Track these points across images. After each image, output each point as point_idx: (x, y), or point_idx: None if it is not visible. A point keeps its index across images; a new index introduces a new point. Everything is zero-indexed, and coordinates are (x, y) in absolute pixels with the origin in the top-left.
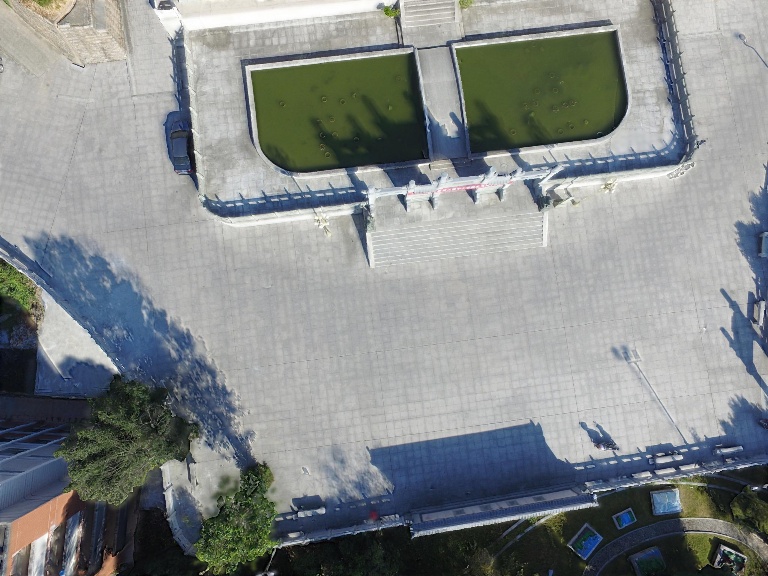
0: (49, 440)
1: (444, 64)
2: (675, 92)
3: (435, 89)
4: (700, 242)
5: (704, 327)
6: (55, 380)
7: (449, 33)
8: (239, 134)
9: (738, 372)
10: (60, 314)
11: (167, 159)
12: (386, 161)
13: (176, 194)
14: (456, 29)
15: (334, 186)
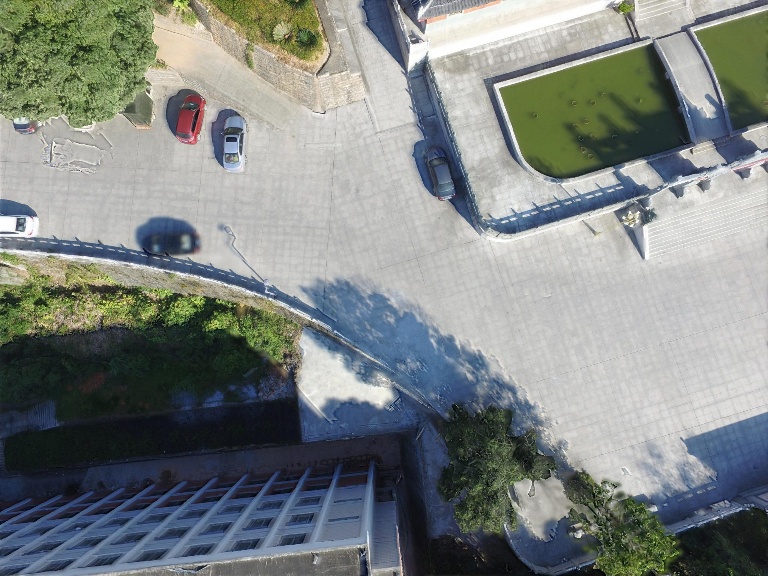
0: (318, 485)
1: (687, 49)
2: None
3: (685, 74)
4: None
5: None
6: (321, 424)
7: (681, 19)
8: (498, 151)
9: None
10: (321, 358)
11: (423, 188)
12: (648, 153)
13: (439, 220)
14: (687, 14)
15: (601, 186)
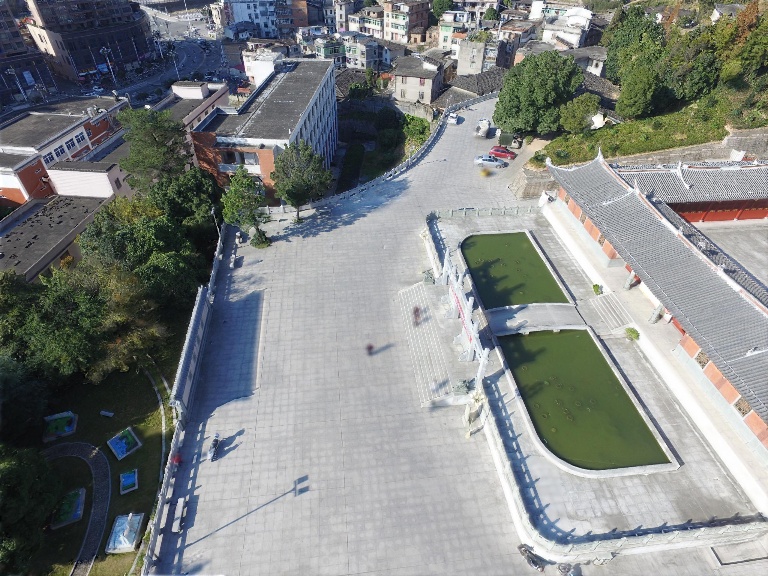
0: None
1: (568, 319)
2: None
3: (544, 312)
4: None
5: None
6: None
7: (599, 327)
8: (482, 230)
9: None
10: None
11: None
12: (479, 290)
13: None
14: (605, 332)
15: None
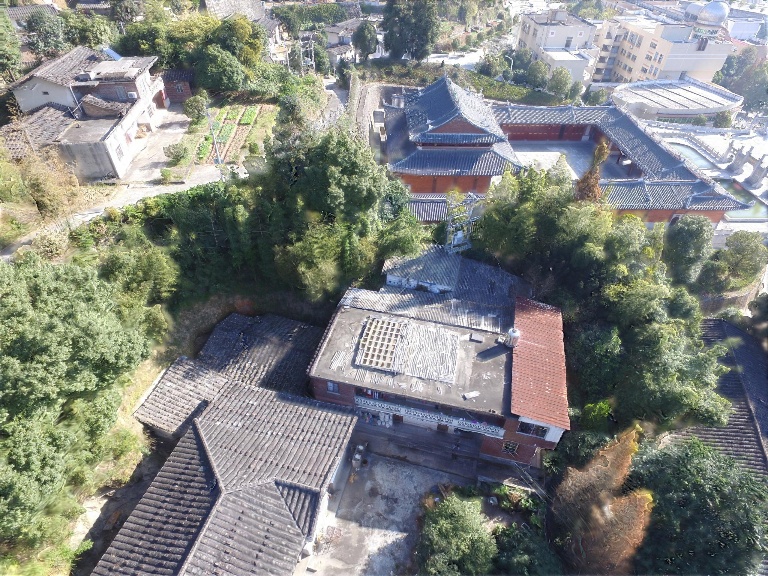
0: None
1: None
2: None
3: None
4: None
5: None
6: None
7: None
8: None
9: None
10: None
11: None
12: None
13: None
14: None
15: None
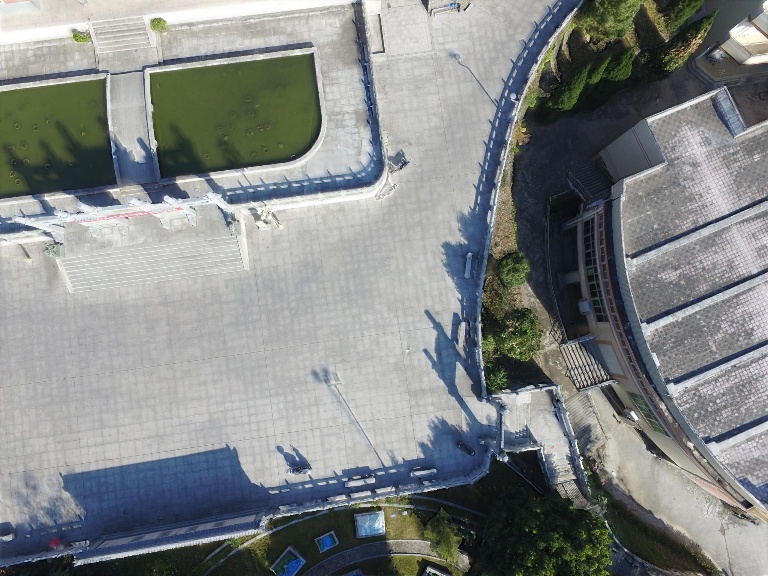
0: None
1: (135, 89)
2: (375, 114)
3: (123, 115)
4: (406, 263)
5: (407, 349)
6: None
7: (145, 58)
8: None
9: (439, 394)
10: None
11: None
12: (77, 187)
13: None
14: (153, 54)
15: (25, 213)
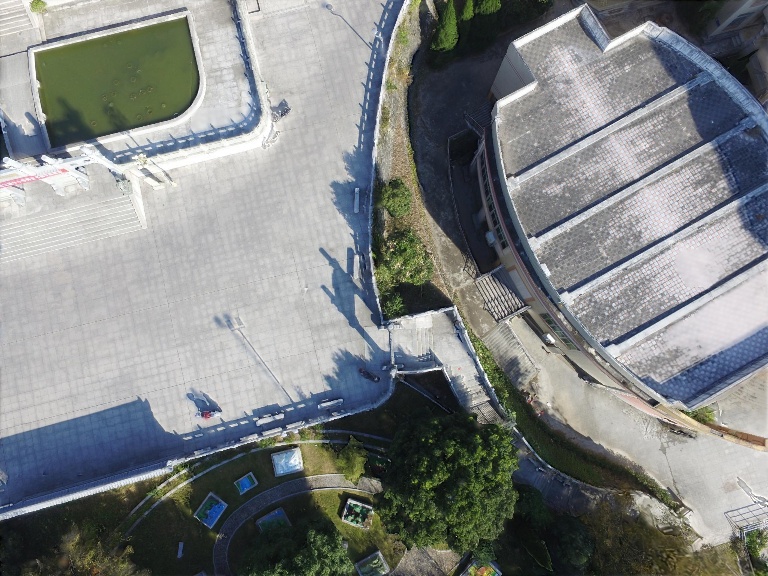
0: None
1: (20, 68)
2: None
3: (10, 93)
4: (297, 206)
5: (305, 287)
6: None
7: (29, 39)
8: None
9: (341, 327)
10: None
11: None
12: None
13: None
14: (36, 34)
15: None
